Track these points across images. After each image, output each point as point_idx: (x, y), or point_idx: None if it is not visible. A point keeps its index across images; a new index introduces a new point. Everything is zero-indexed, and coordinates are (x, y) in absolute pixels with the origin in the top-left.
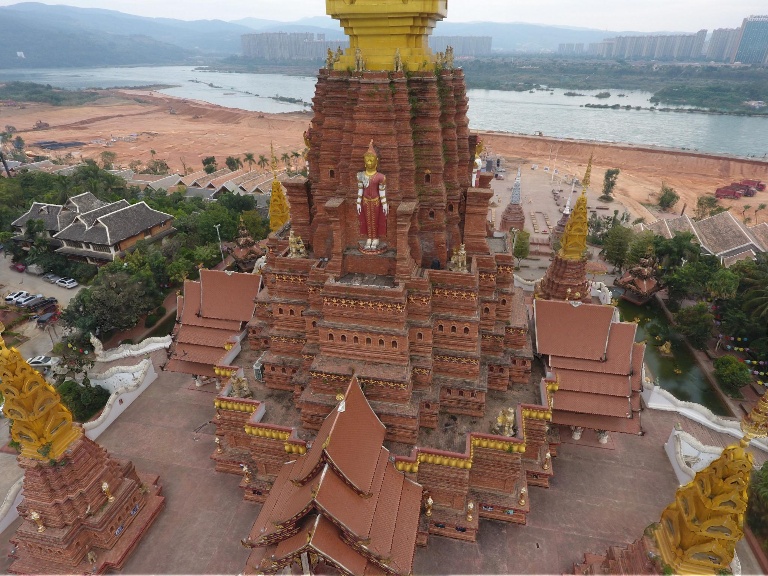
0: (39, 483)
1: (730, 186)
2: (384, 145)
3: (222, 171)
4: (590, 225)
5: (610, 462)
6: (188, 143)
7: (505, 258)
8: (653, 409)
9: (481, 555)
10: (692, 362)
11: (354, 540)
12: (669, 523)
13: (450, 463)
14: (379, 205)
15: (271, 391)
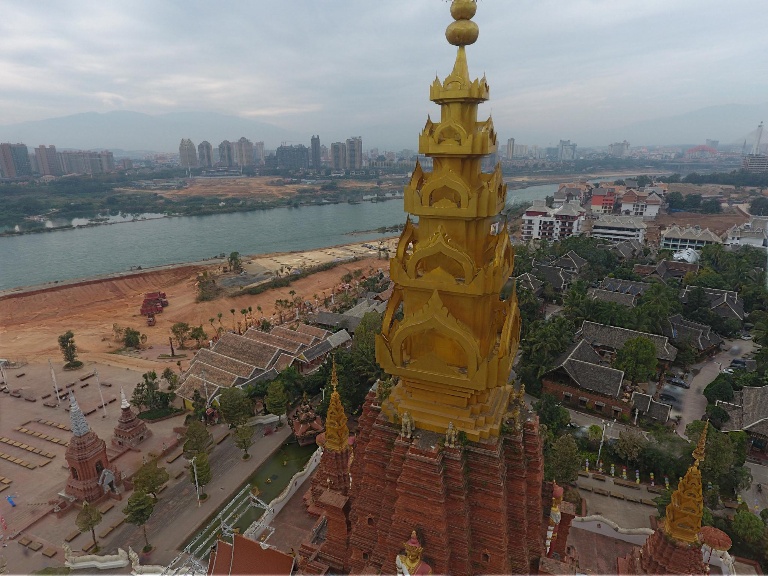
0: None
1: (146, 304)
2: None
3: None
4: (138, 402)
5: None
6: None
7: None
8: None
9: None
10: None
11: None
12: (680, 526)
13: None
14: None
15: None
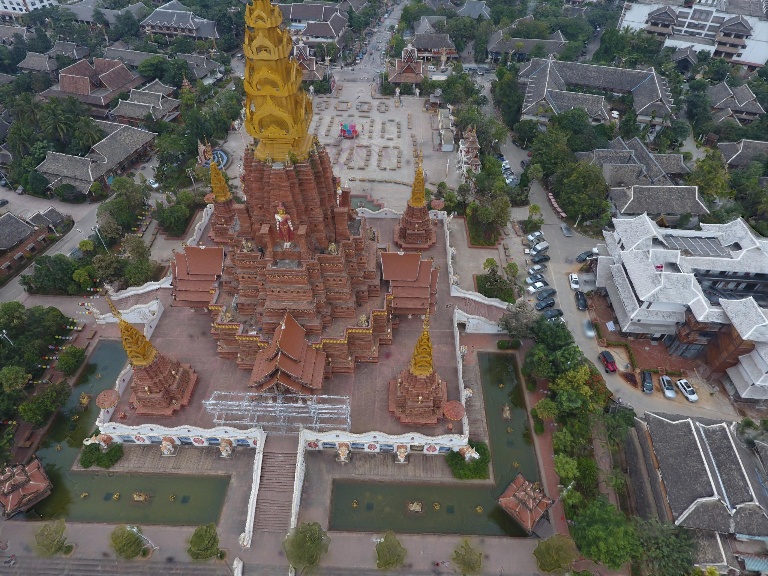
0: None
1: None
2: None
3: None
4: None
5: None
6: None
7: None
8: None
9: None
10: (74, 391)
11: None
12: None
13: None
14: None
15: None
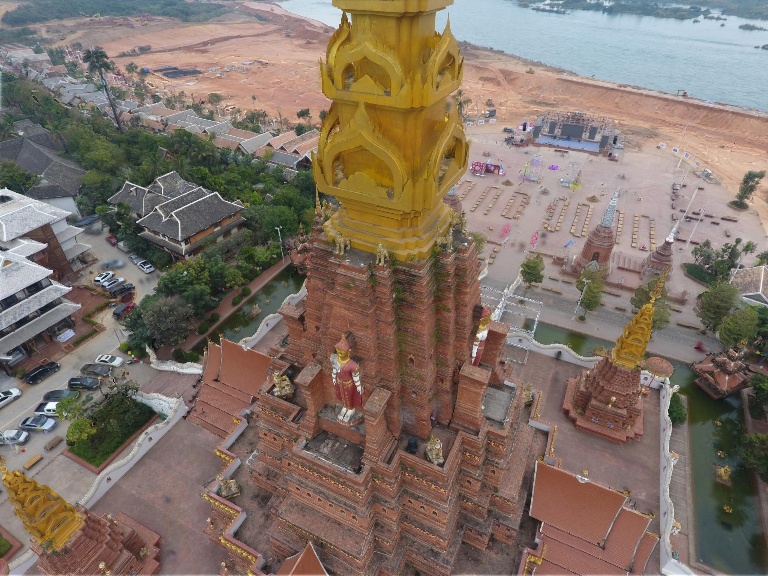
0: None
1: None
2: (360, 335)
3: (310, 133)
4: (699, 253)
5: None
6: (294, 78)
7: (498, 436)
8: None
9: None
10: (752, 499)
11: None
12: None
13: None
14: (353, 386)
15: (258, 490)
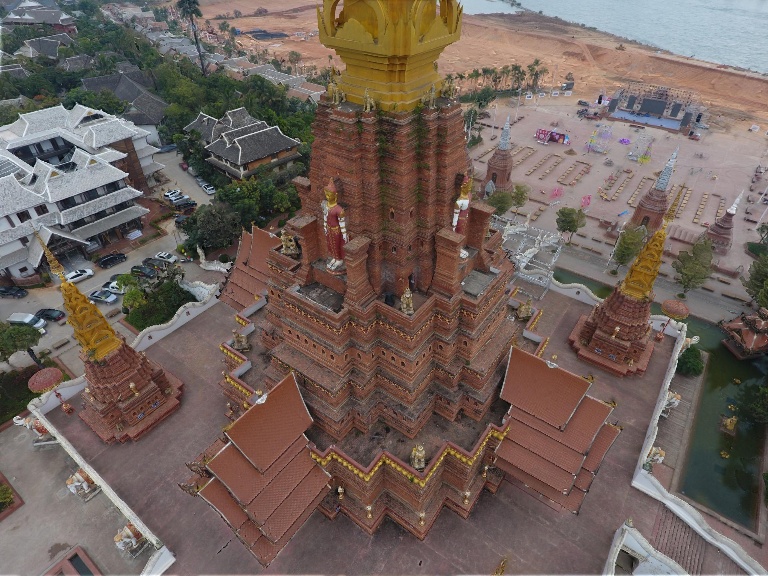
0: (90, 371)
1: None
2: (346, 181)
3: None
4: (766, 231)
5: (544, 522)
6: None
7: (470, 304)
8: (636, 489)
9: (370, 547)
10: (755, 450)
11: (237, 502)
12: None
13: (353, 470)
14: (339, 233)
15: (265, 350)
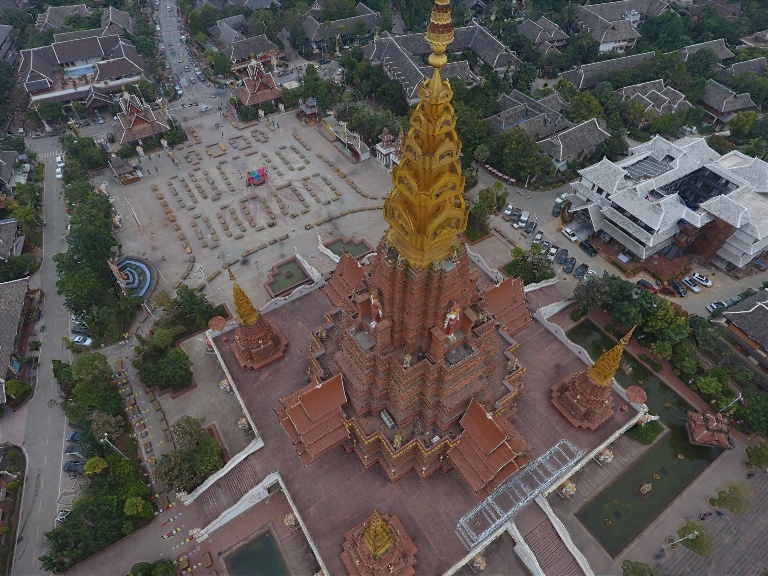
0: None
1: None
2: None
3: None
4: None
5: None
6: None
7: None
8: None
9: None
10: None
11: None
12: None
13: None
14: None
15: None
